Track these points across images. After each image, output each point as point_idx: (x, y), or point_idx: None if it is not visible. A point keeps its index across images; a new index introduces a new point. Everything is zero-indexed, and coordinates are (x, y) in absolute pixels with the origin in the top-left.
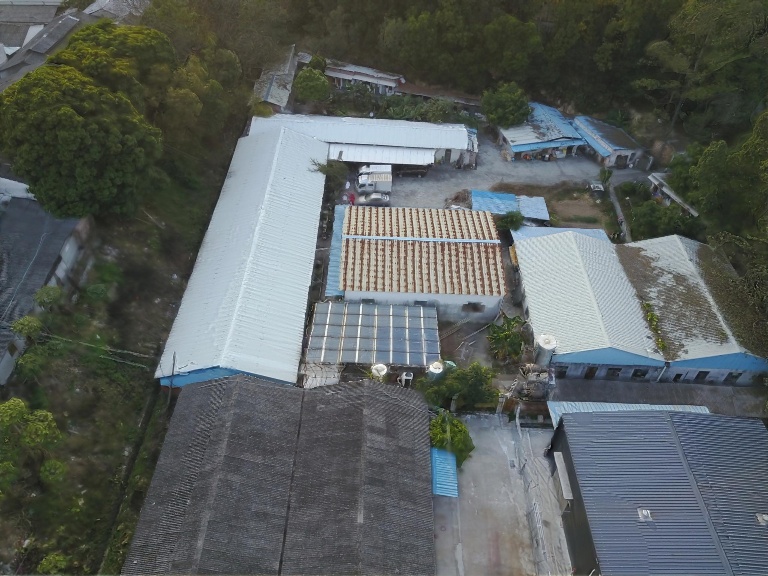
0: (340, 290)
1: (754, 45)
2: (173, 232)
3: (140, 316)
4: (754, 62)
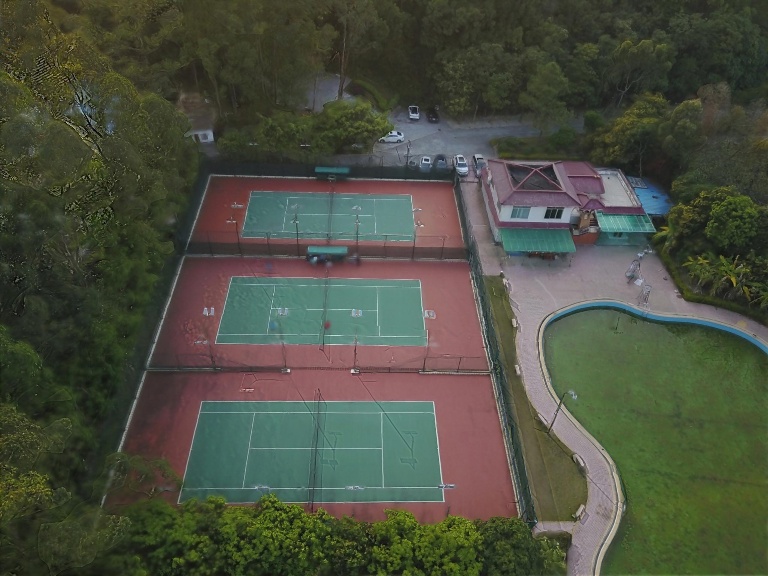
0: None
1: (161, 19)
2: None
3: None
4: (204, 38)
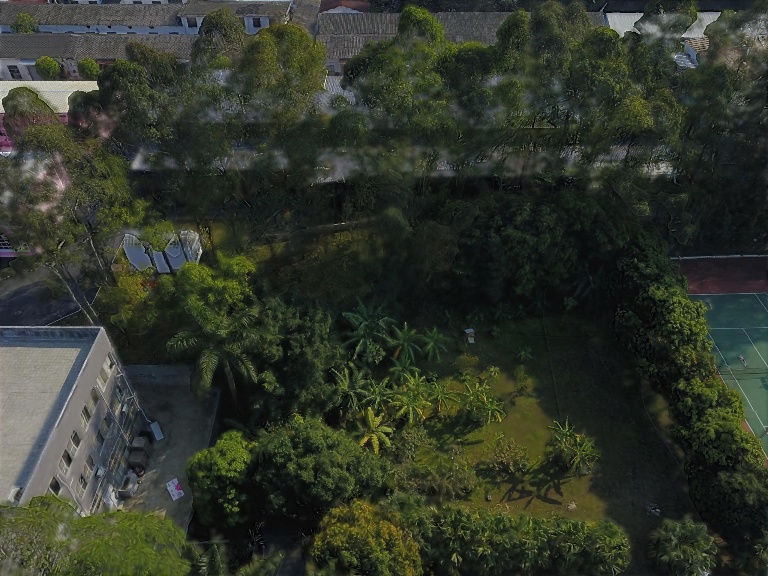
0: (685, 41)
1: None
2: (695, 6)
3: (628, 7)
4: None
